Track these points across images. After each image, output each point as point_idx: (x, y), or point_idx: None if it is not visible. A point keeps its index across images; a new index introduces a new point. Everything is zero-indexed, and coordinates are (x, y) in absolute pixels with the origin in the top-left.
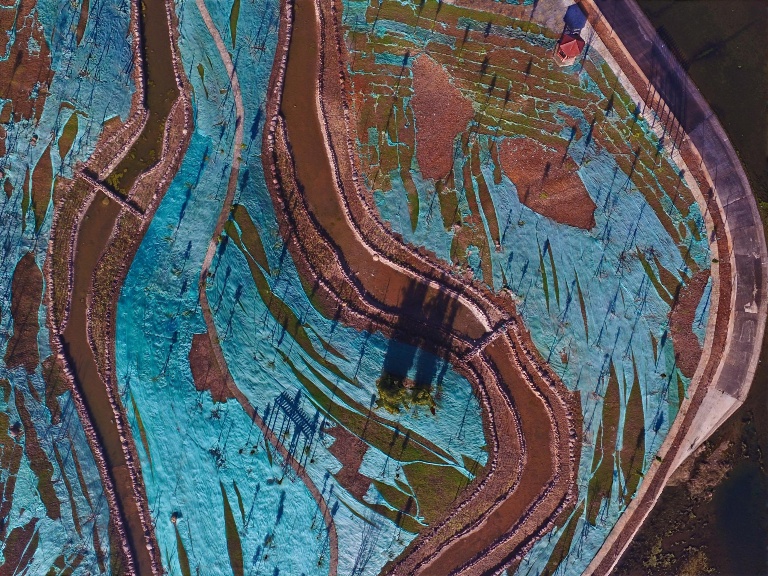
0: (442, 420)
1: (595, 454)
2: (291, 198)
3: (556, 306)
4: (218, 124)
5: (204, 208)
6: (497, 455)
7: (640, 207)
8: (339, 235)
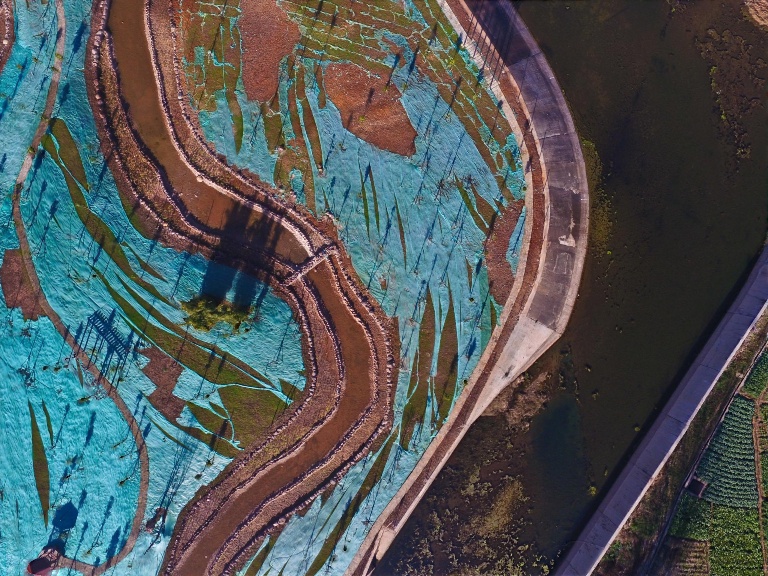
0: (260, 343)
1: (411, 380)
2: (115, 115)
3: (376, 232)
4: (38, 35)
5: (21, 120)
6: (315, 380)
7: (459, 136)
8: (163, 155)
